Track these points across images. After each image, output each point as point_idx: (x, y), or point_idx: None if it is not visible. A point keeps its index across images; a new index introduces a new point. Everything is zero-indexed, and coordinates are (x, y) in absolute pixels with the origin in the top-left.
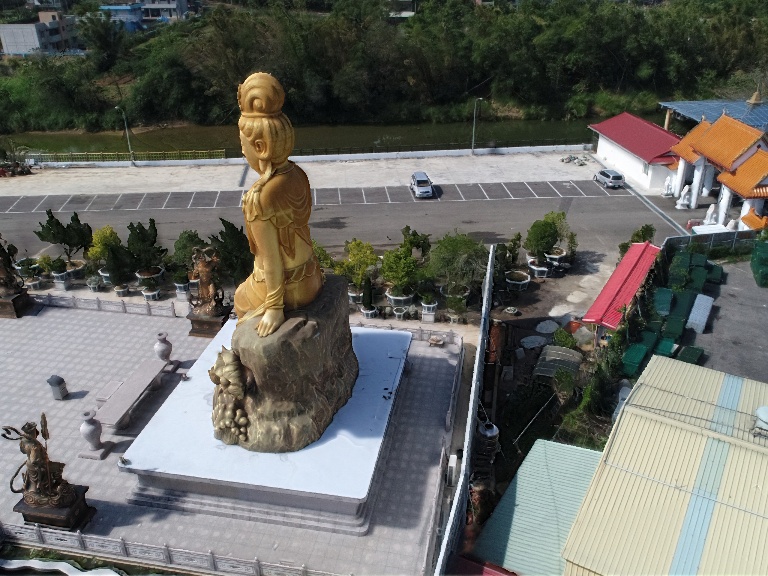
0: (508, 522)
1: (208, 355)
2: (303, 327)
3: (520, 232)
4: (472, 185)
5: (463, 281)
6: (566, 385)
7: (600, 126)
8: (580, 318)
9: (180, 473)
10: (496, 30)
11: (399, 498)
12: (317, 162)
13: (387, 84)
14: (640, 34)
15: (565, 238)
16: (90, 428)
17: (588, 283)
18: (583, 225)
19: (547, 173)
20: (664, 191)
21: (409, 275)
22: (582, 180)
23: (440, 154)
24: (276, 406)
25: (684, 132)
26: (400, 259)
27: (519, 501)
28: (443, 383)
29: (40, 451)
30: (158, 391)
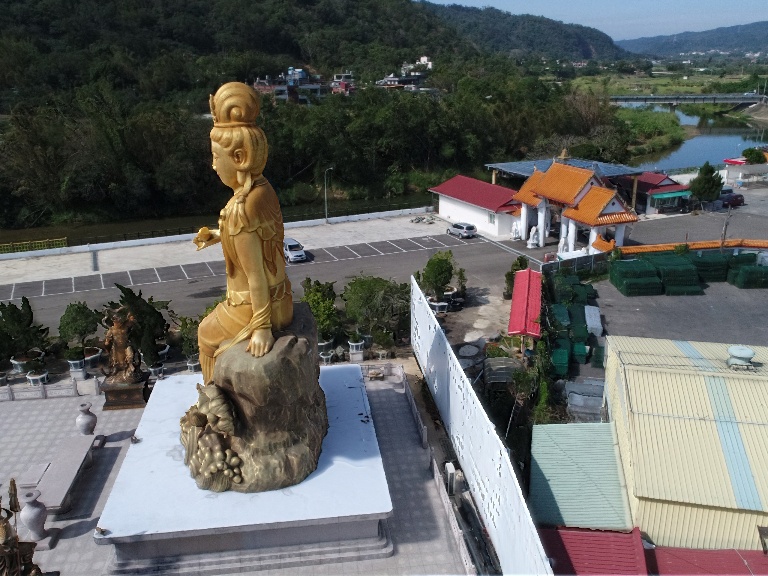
0: (549, 495)
1: (150, 416)
2: (296, 344)
3: (404, 279)
4: (339, 247)
5: (385, 316)
6: (524, 385)
7: (439, 188)
8: (495, 339)
9: (176, 530)
10: (313, 119)
11: (409, 515)
12: (171, 243)
13: (213, 174)
14: (439, 119)
15: (454, 275)
16: (35, 511)
17: (486, 312)
18: (457, 268)
19: (403, 232)
20: (513, 235)
21: (330, 318)
22: (437, 235)
23: (295, 225)
24: (270, 438)
25: (511, 188)
26: (318, 303)
27: (549, 476)
28: (399, 409)
29: (8, 529)
30: (91, 468)
